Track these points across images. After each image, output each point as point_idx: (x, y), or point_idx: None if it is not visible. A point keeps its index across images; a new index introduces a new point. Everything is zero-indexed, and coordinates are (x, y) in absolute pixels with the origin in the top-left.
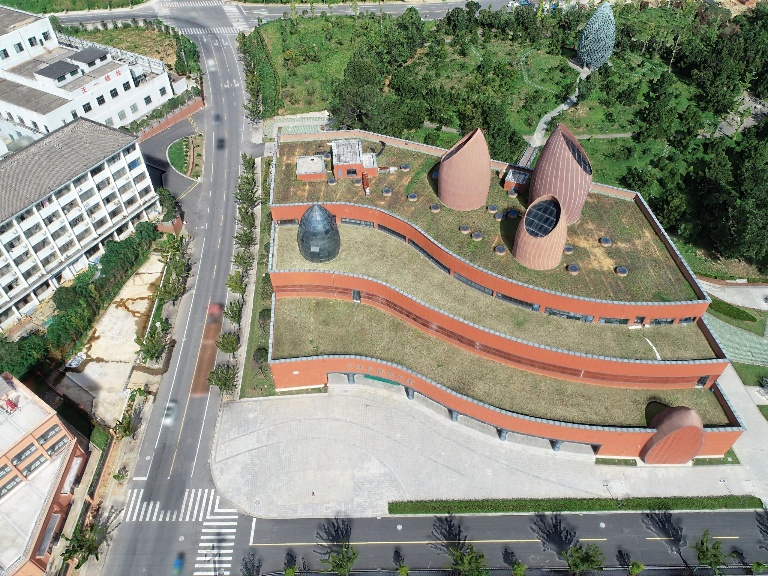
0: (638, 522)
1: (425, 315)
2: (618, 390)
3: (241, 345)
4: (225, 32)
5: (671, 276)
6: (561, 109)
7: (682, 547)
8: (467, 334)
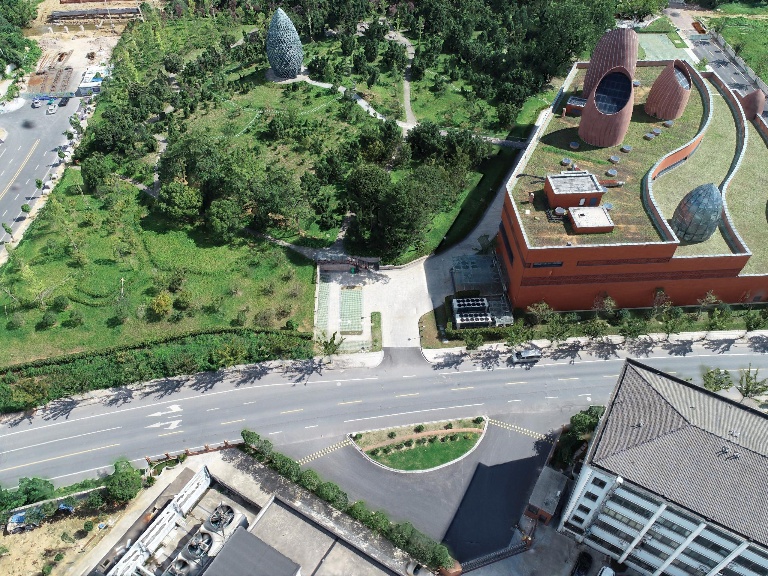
0: None
1: None
2: None
3: (761, 335)
4: None
5: (660, 70)
6: (364, 104)
7: None
8: None
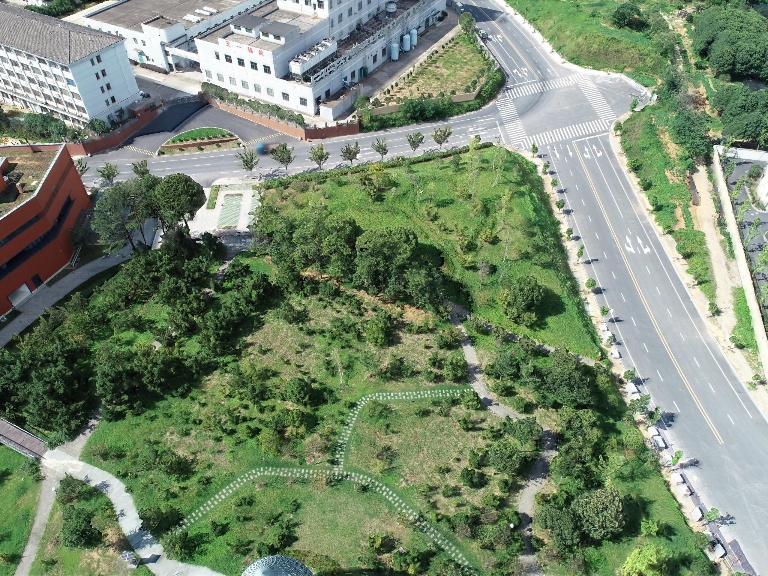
0: None
1: None
2: None
3: None
4: (509, 131)
5: None
6: (128, 518)
7: None
8: None
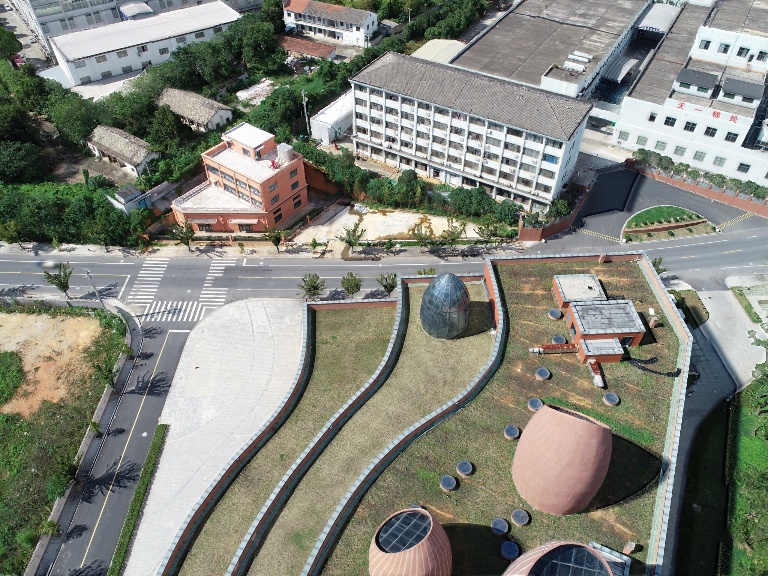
0: None
1: None
2: None
3: None
4: None
5: None
6: None
7: None
8: None
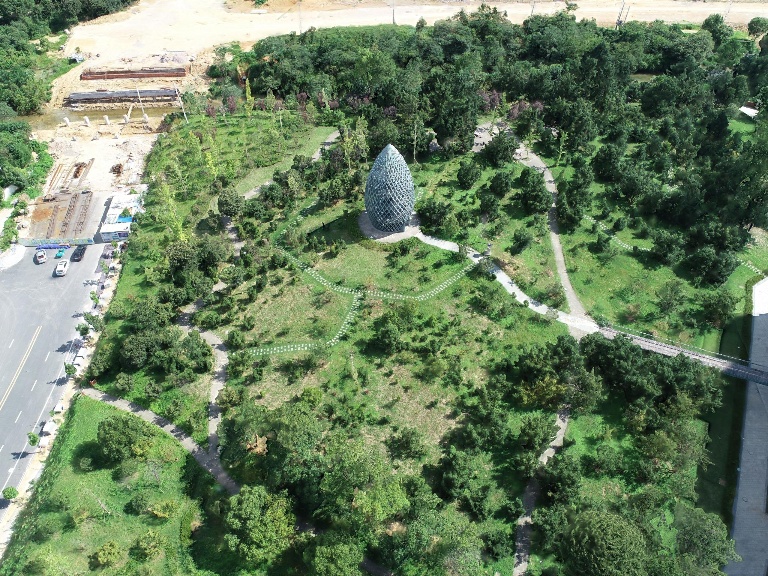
0: None
1: None
2: None
3: None
4: None
5: None
6: (504, 279)
7: None
8: None
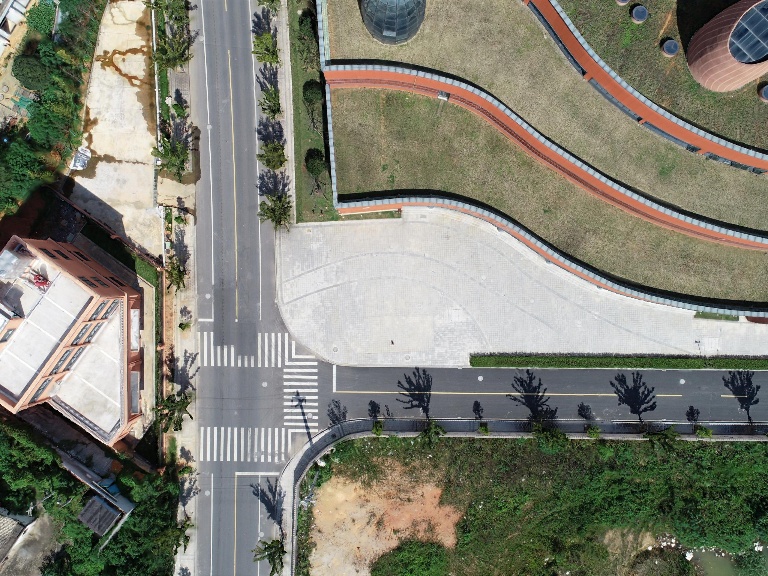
0: (718, 380)
1: (540, 148)
2: (755, 253)
3: (286, 140)
4: None
5: None
6: None
7: (752, 405)
8: (592, 182)
